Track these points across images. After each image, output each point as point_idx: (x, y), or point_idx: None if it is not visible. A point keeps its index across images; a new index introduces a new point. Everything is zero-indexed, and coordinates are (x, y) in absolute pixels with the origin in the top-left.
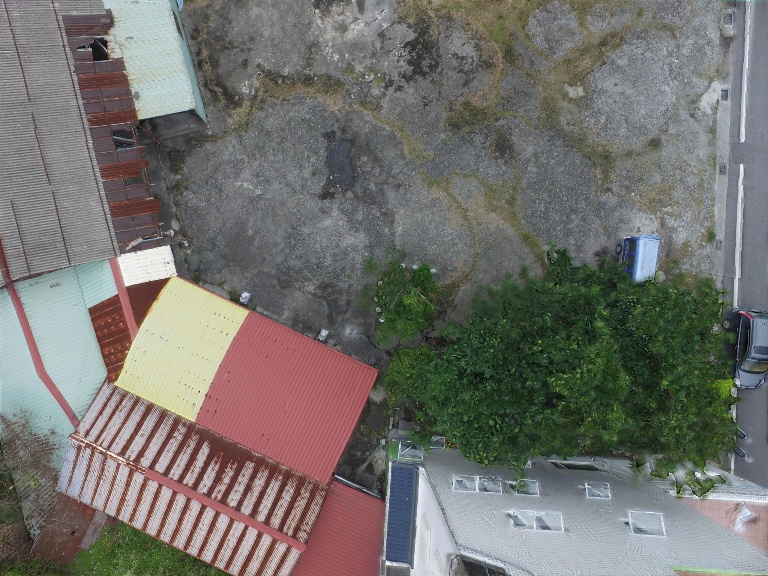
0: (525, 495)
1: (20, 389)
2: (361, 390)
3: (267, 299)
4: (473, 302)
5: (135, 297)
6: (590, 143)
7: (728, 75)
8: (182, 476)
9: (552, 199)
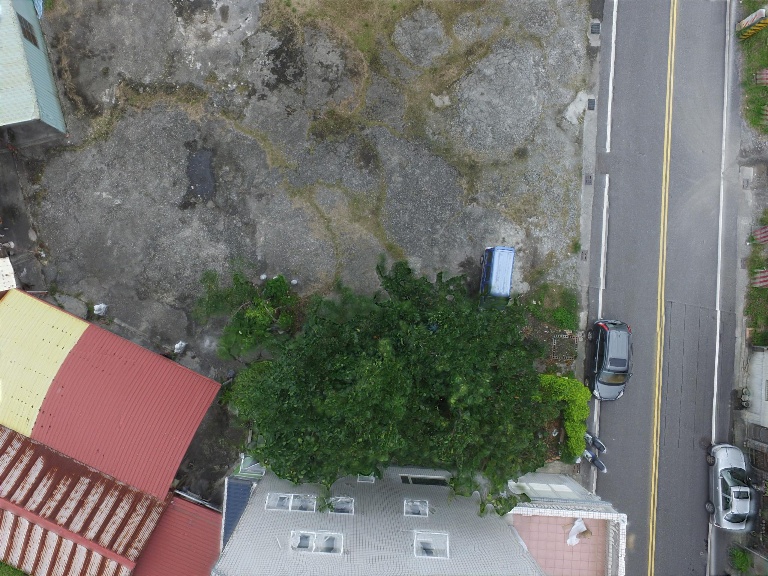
0: (338, 513)
1: None
2: (200, 404)
3: (125, 311)
4: (335, 313)
5: None
6: (455, 153)
7: (595, 84)
8: (10, 493)
9: (416, 209)
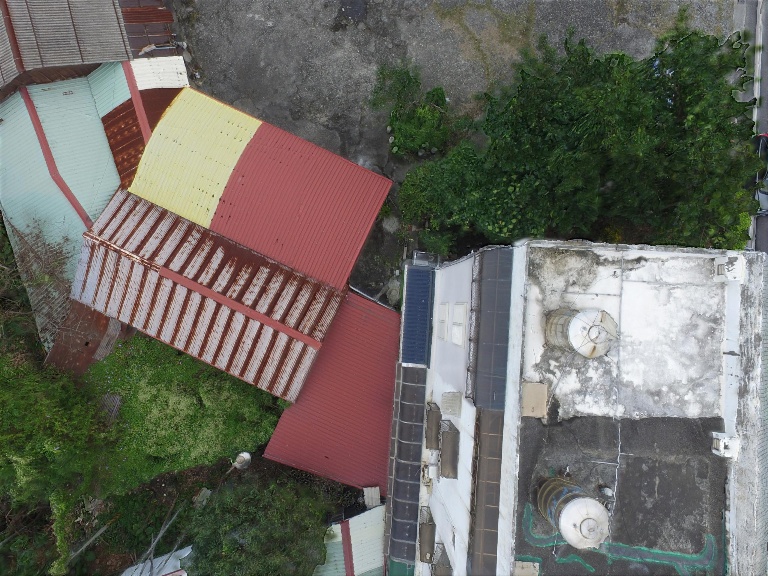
0: None
1: (34, 195)
2: (376, 197)
3: None
4: None
5: (148, 101)
6: None
7: None
8: (196, 276)
9: (567, 29)
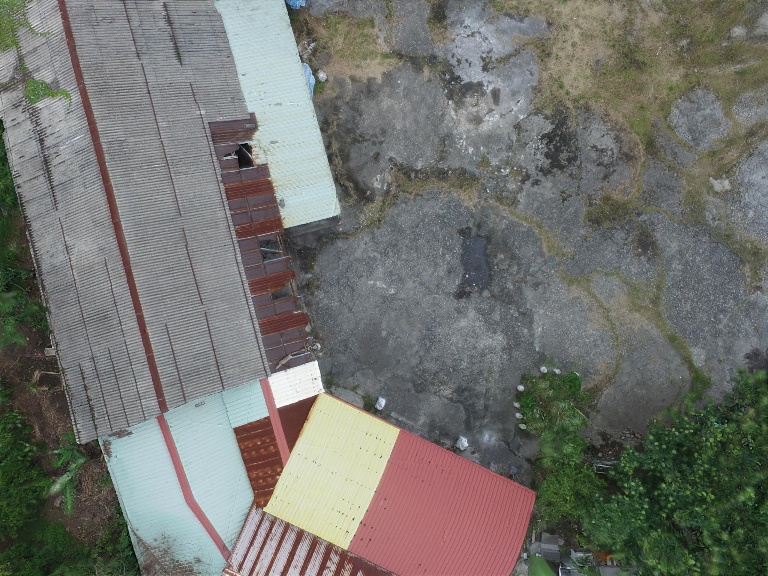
0: None
1: (165, 515)
2: (521, 516)
3: (402, 404)
4: (617, 407)
5: (286, 419)
6: (737, 239)
7: None
8: None
9: (698, 298)
